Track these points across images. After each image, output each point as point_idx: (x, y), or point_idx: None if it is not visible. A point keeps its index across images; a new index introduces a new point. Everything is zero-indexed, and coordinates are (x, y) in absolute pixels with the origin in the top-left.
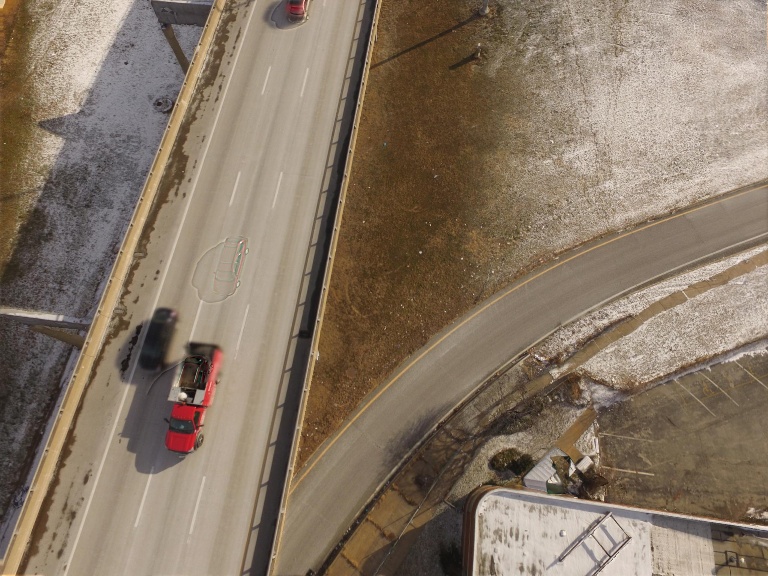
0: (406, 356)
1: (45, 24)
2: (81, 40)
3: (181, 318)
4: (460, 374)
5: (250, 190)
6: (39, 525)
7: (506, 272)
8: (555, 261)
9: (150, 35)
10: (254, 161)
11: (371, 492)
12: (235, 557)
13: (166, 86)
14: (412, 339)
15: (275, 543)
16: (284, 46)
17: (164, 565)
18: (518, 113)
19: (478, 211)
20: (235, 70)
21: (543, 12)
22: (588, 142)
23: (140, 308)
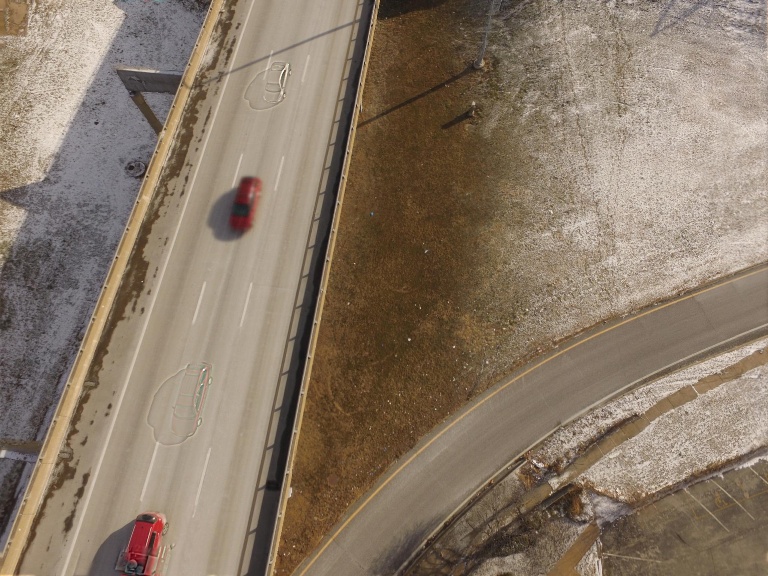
0: (393, 461)
1: (8, 83)
2: (47, 99)
3: (134, 464)
4: (451, 482)
5: (216, 305)
6: None
7: (501, 363)
8: (554, 350)
9: (123, 91)
10: (221, 269)
11: None
12: None
13: (139, 147)
14: (399, 441)
15: None
16: (258, 130)
17: None
18: (515, 179)
19: (472, 292)
20: (203, 158)
21: (542, 66)
22: (590, 212)
23: (88, 452)
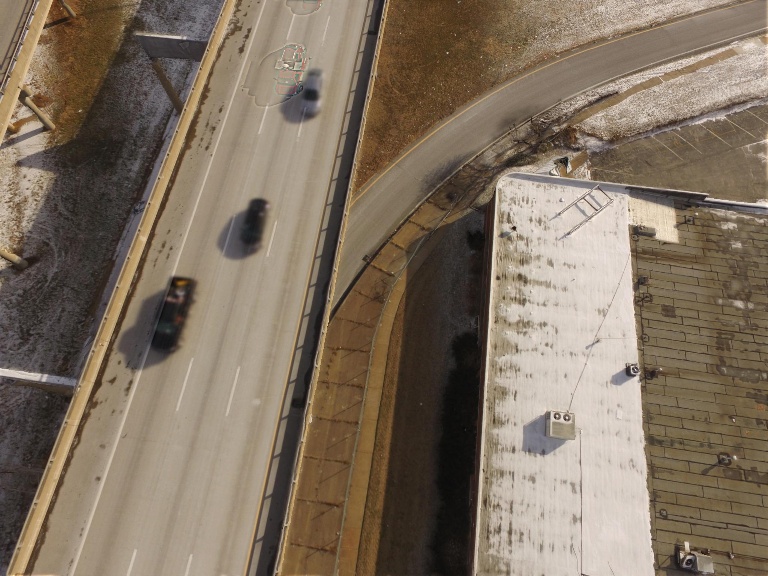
0: (437, 121)
1: None
2: None
3: (280, 24)
4: (481, 133)
5: None
6: (190, 134)
7: (517, 65)
8: (557, 58)
9: None
10: None
11: (412, 208)
12: (331, 148)
13: None
14: (442, 109)
15: (360, 133)
16: None
17: (281, 152)
18: None
19: (494, 25)
20: None
21: None
22: None
23: (249, 19)
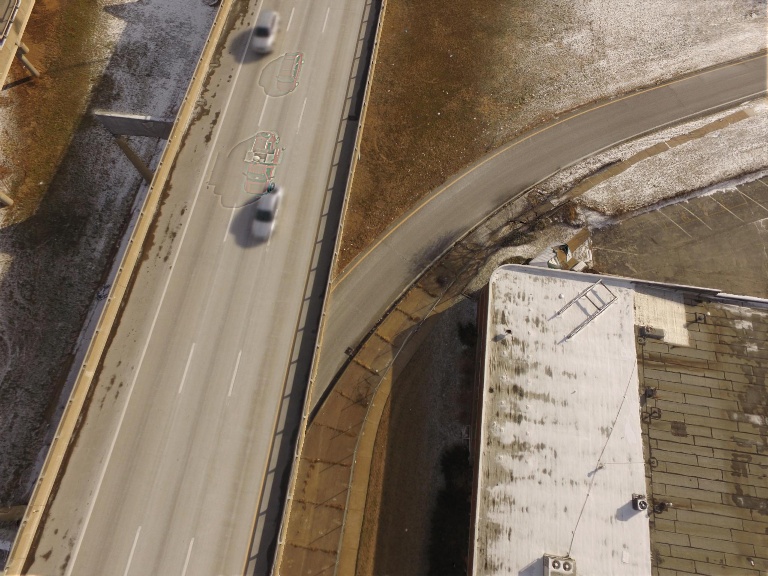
0: (427, 191)
1: None
2: None
3: (251, 107)
4: (474, 205)
5: (303, 20)
6: (148, 241)
7: (513, 128)
8: (555, 120)
9: None
10: (305, 0)
11: (399, 292)
12: (304, 260)
13: None
14: (432, 179)
15: (337, 244)
16: None
17: (249, 265)
18: (523, 7)
19: (489, 82)
20: None
21: None
22: (585, 29)
23: (217, 100)
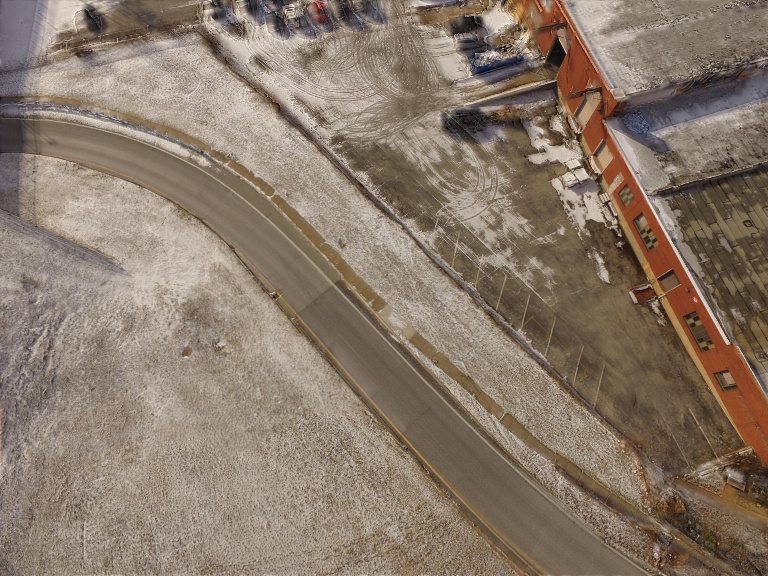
0: None
1: None
2: None
3: None
4: None
5: None
6: None
7: None
8: None
9: None
10: None
11: None
12: None
13: None
14: None
15: None
16: None
17: None
18: None
19: None
20: None
21: None
22: None
23: None
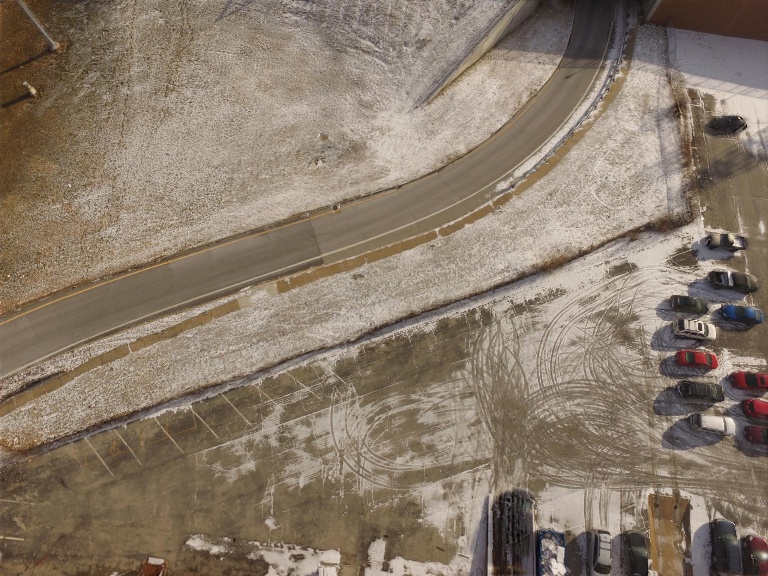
0: None
1: None
2: None
3: None
4: None
5: None
6: None
7: None
8: (16, 313)
9: None
10: None
11: None
12: None
13: None
14: None
15: None
16: None
17: None
18: (47, 155)
19: None
20: None
21: (107, 49)
22: (105, 186)
23: None
